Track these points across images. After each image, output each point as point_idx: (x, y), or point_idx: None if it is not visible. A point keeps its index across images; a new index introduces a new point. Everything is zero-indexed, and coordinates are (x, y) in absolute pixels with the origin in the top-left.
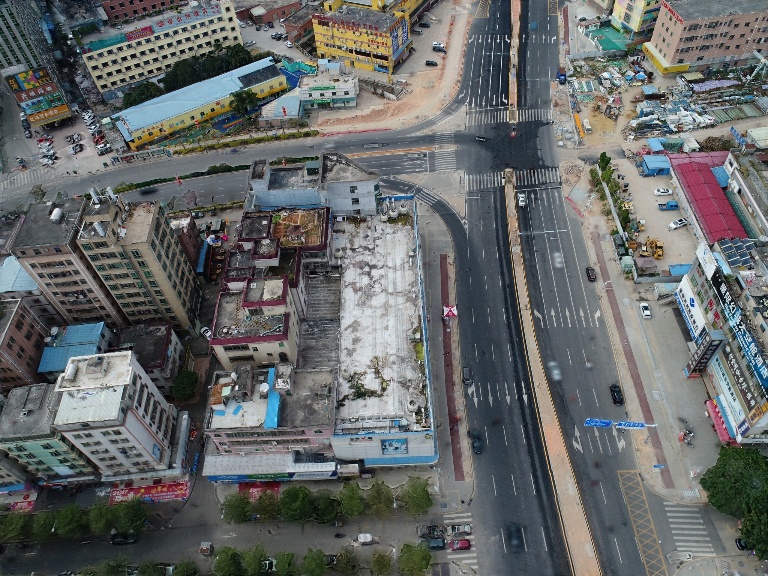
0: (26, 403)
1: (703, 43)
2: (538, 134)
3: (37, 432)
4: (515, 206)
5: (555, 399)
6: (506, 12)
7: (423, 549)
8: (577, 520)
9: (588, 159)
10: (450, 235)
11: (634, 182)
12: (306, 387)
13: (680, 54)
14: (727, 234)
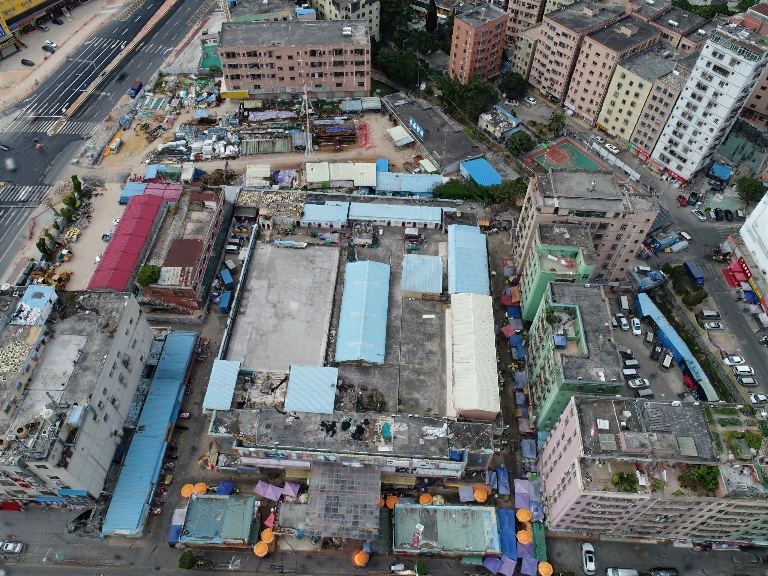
0: None
1: (252, 72)
2: (64, 148)
3: None
4: None
5: None
6: (147, 17)
7: None
8: None
9: (89, 180)
10: None
11: (107, 209)
12: None
13: (232, 80)
14: (108, 274)
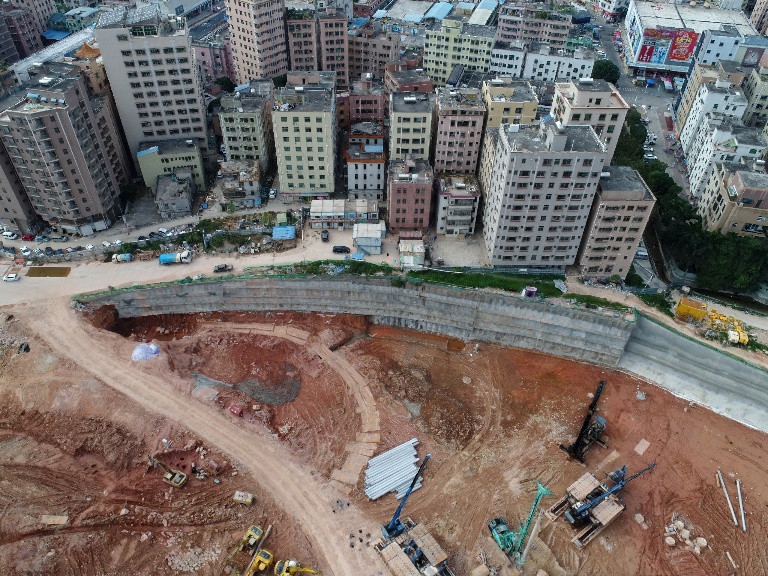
0: None
1: None
2: None
3: None
4: None
5: None
6: None
7: None
8: None
9: None
10: None
11: None
12: None
13: None
14: None
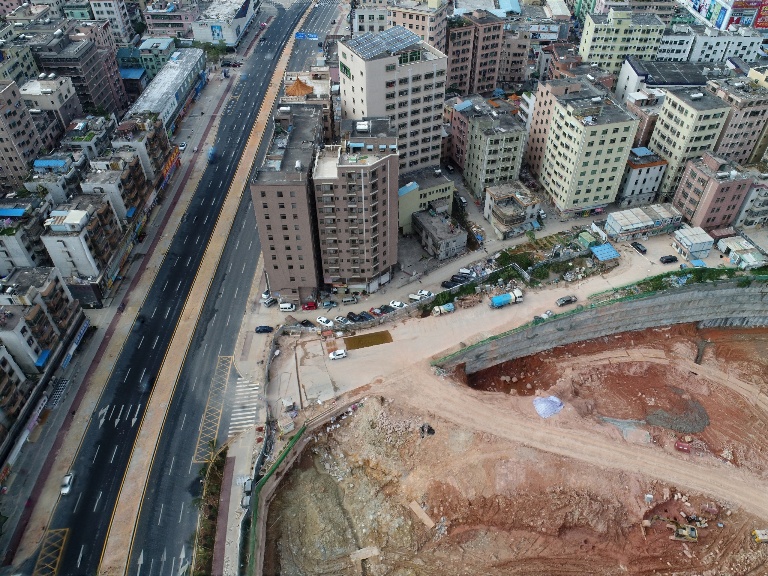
0: (77, 0)
1: None
2: None
3: (80, 5)
4: (313, 7)
5: (295, 45)
6: None
7: (217, 50)
8: (284, 63)
9: None
10: (278, 12)
11: None
12: (186, 8)
13: None
14: None
